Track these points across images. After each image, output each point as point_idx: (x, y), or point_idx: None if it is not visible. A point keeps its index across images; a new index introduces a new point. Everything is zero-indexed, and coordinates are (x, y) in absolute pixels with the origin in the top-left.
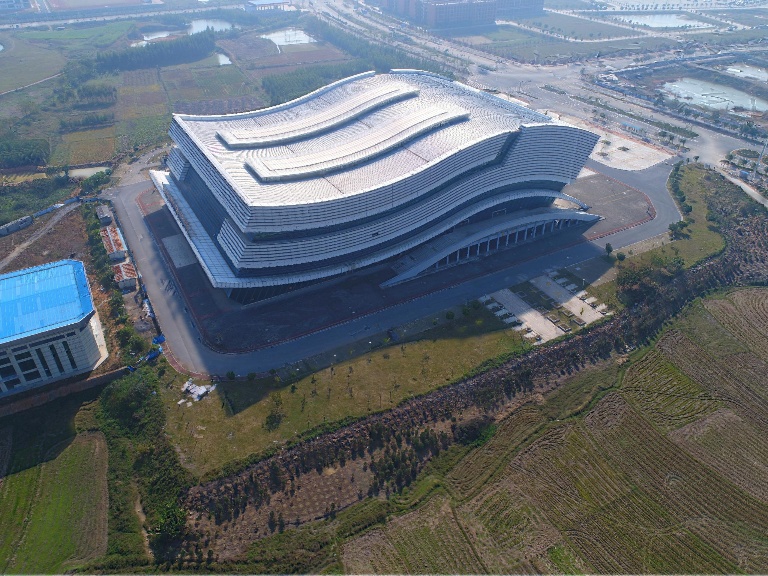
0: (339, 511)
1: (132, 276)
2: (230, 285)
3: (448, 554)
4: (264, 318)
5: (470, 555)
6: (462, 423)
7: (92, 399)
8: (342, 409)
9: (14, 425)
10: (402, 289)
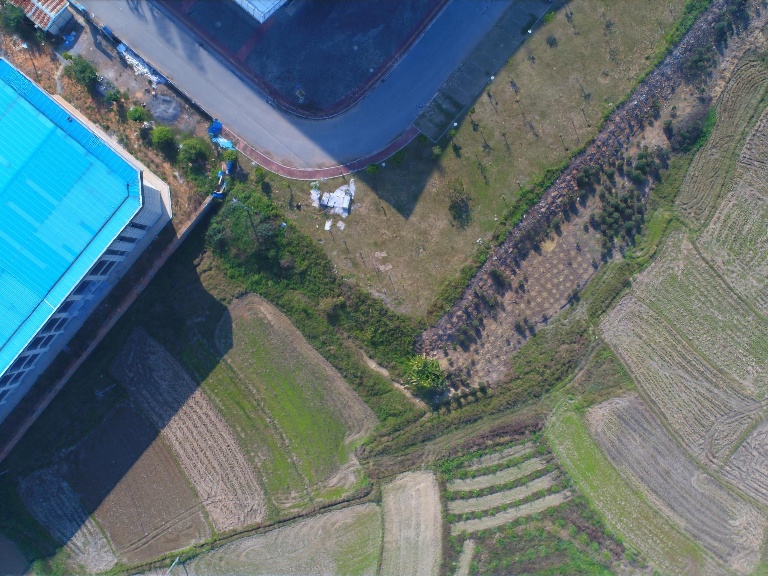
0: (581, 291)
1: (57, 5)
2: (279, 4)
3: (702, 296)
4: (337, 24)
5: (723, 289)
6: (680, 124)
7: (200, 253)
8: (534, 162)
9: (140, 325)
10: None
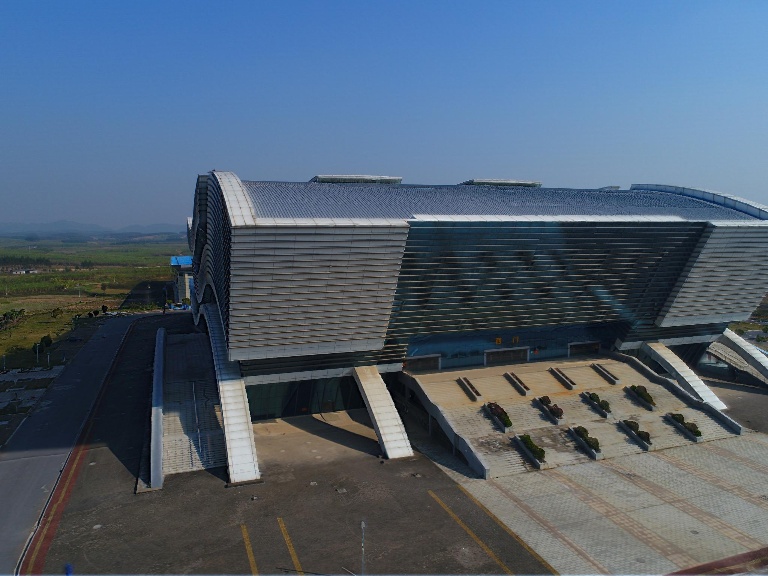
0: None
1: None
2: None
3: None
4: None
5: None
6: None
7: None
8: None
9: None
10: (145, 344)
